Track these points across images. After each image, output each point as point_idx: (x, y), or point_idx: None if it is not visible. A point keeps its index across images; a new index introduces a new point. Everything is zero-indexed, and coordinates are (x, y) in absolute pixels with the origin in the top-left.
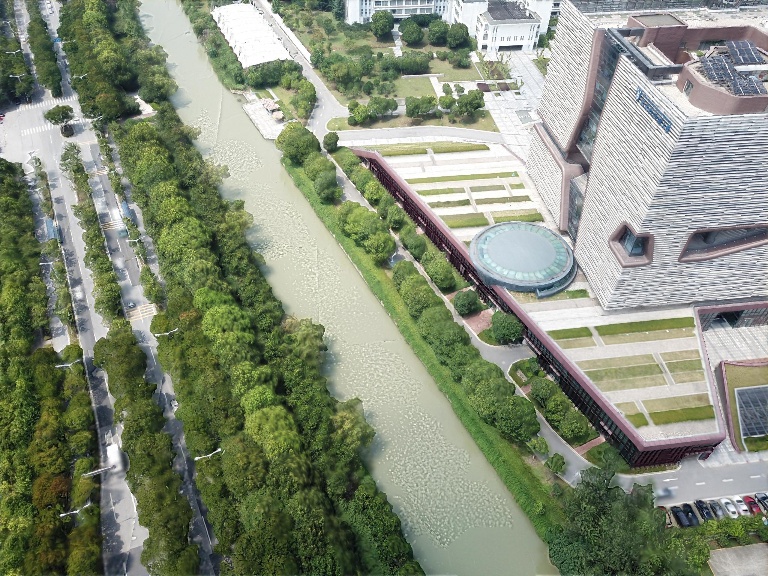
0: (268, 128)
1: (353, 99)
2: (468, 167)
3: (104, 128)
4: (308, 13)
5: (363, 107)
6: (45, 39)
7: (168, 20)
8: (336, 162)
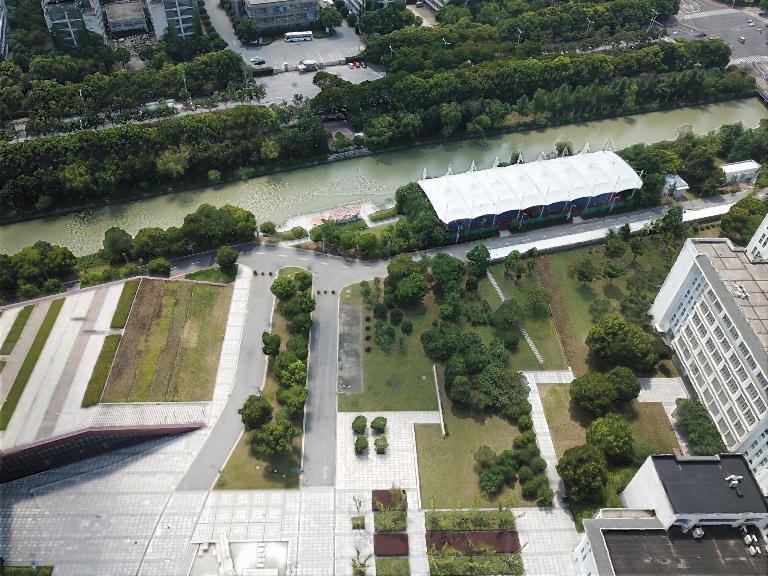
0: (306, 219)
1: (364, 298)
2: (53, 370)
3: (328, 115)
4: (670, 256)
5: (278, 281)
6: (472, 51)
7: (650, 144)
8: (200, 270)
